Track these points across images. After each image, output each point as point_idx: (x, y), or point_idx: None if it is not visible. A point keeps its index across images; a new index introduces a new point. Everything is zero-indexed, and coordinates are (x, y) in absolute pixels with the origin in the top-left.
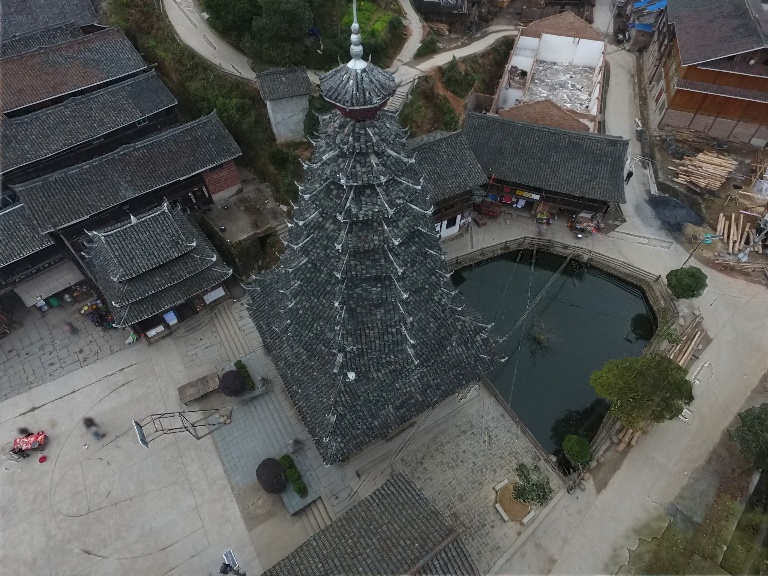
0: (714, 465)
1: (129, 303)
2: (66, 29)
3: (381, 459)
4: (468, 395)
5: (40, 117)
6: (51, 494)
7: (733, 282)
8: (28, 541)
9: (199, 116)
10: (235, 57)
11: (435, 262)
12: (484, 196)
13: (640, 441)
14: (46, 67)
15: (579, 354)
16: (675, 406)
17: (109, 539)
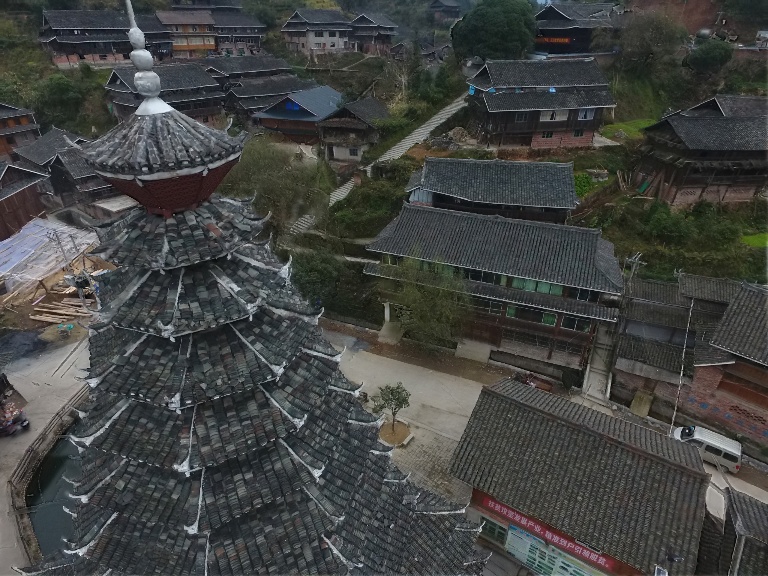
0: None
1: None
2: None
3: None
4: None
5: None
6: None
7: None
8: None
9: None
10: None
11: None
12: None
13: None
14: None
15: None
16: None
17: None
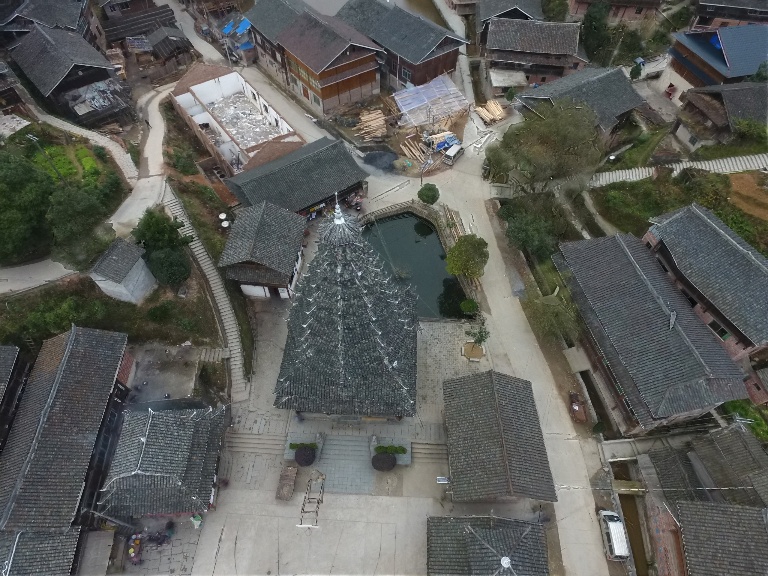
0: (508, 263)
1: None
2: None
3: None
4: None
5: None
6: None
7: (438, 177)
8: None
9: (41, 343)
10: (8, 275)
11: None
12: None
13: (481, 280)
14: None
15: (422, 267)
16: None
17: None
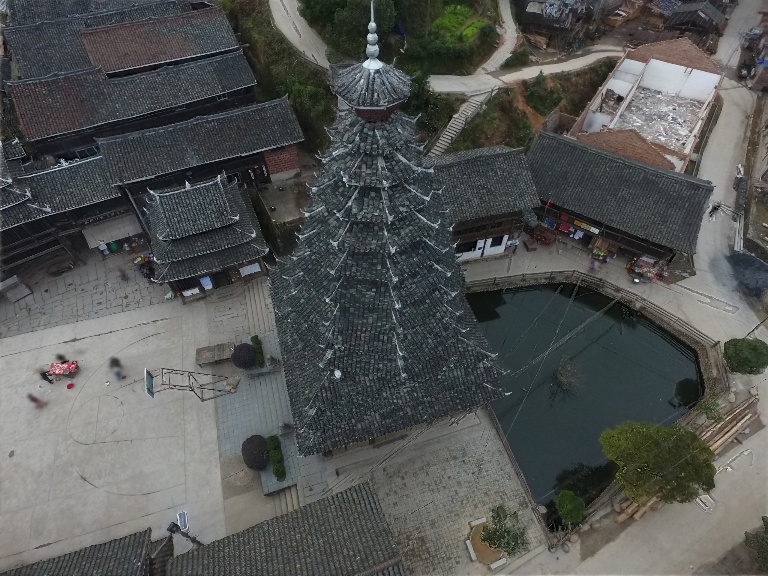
0: (728, 567)
1: (170, 262)
2: (178, 4)
3: (364, 463)
4: (469, 421)
5: (135, 80)
6: (69, 418)
7: None
8: (40, 455)
9: None
10: (320, 46)
11: (439, 278)
12: (540, 220)
13: (646, 517)
14: (151, 36)
15: (603, 407)
16: (690, 489)
17: (104, 472)
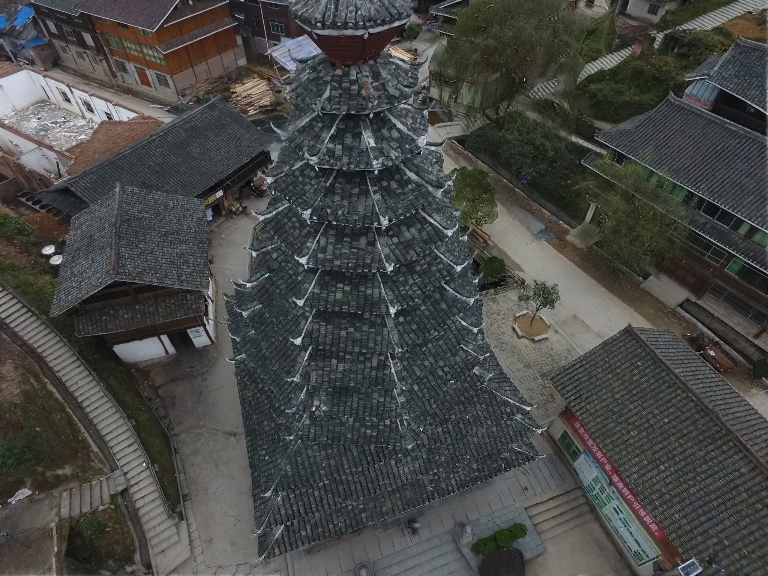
0: (507, 204)
1: None
2: None
3: None
4: None
5: None
6: None
7: None
8: None
9: None
10: None
11: None
12: None
13: None
14: None
15: None
16: None
17: None
